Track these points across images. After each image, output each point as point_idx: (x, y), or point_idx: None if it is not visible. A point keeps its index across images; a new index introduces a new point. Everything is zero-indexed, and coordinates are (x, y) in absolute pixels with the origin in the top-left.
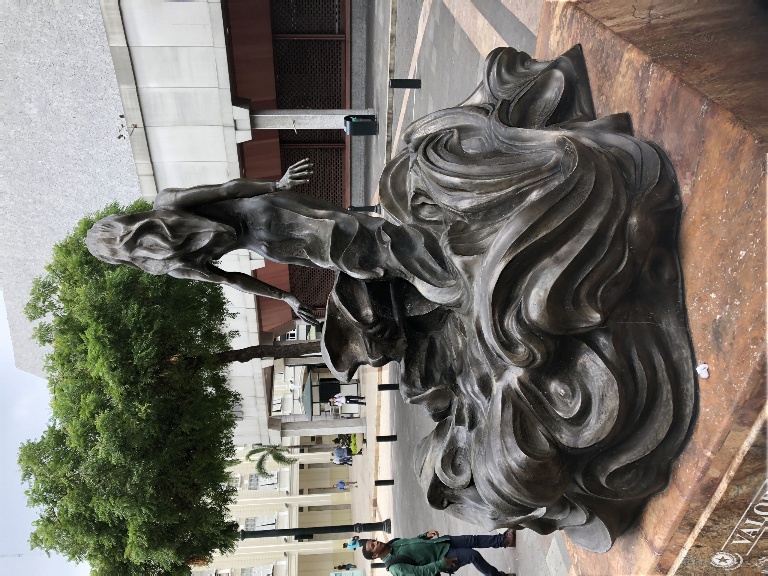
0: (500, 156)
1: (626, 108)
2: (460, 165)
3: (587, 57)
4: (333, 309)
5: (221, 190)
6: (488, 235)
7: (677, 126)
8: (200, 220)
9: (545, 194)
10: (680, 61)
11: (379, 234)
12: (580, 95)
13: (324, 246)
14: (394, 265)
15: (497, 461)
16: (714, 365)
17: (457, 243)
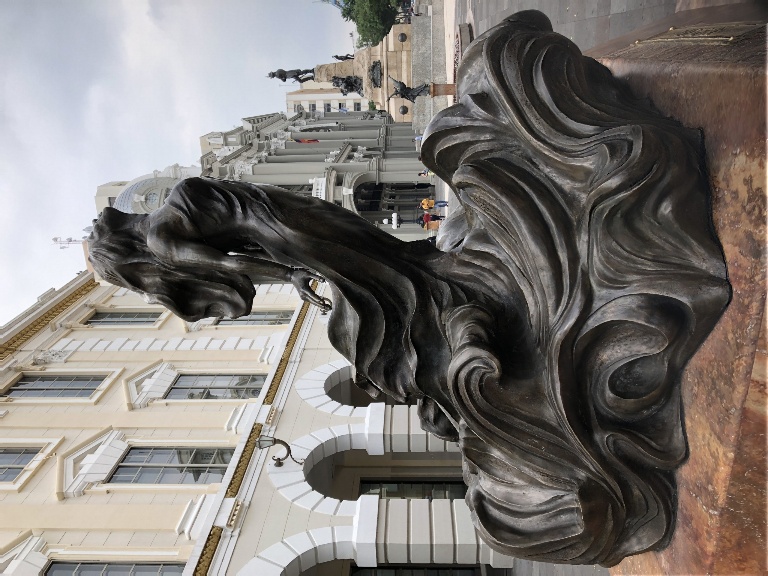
0: (539, 402)
1: (691, 450)
2: (487, 422)
3: (722, 327)
4: (361, 377)
5: (224, 270)
6: (500, 453)
7: (686, 558)
8: (210, 283)
9: (537, 544)
10: (740, 537)
11: (406, 340)
12: (683, 344)
13: (349, 334)
14: (417, 389)
15: (471, 509)
16: (619, 572)
17: (471, 446)
